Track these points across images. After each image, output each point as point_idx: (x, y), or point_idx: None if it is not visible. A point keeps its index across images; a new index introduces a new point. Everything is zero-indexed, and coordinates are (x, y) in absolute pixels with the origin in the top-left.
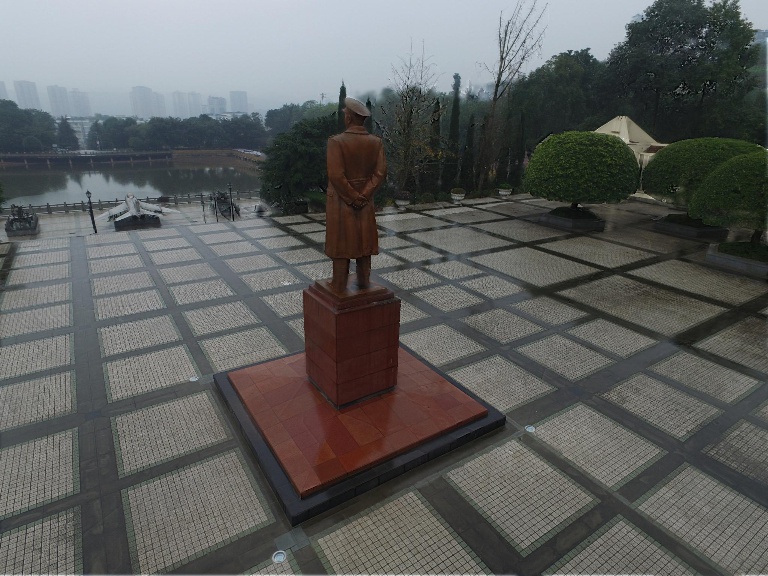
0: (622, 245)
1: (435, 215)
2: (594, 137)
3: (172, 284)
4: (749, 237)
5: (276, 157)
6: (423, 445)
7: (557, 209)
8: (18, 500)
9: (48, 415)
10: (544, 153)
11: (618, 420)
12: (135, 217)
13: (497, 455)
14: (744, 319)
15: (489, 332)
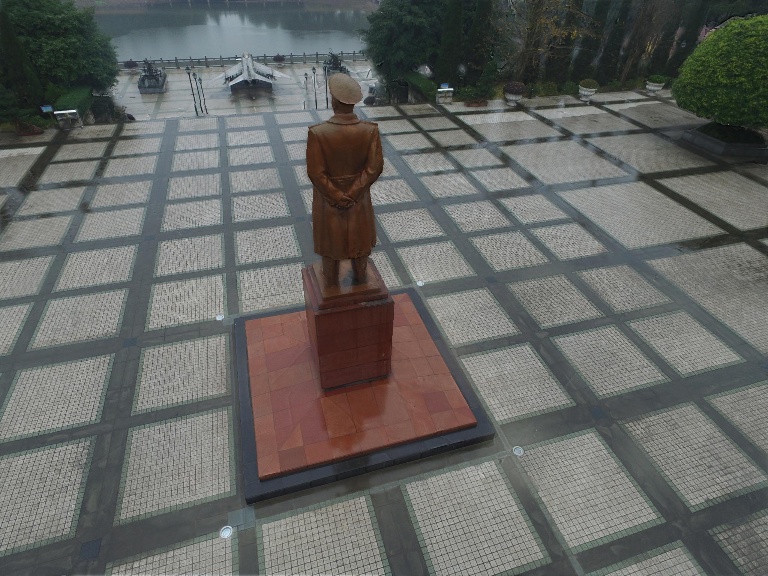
0: None
1: (548, 118)
2: None
3: (236, 194)
4: None
5: (380, 27)
6: (393, 449)
7: (711, 125)
8: (56, 418)
9: (97, 335)
10: (711, 48)
11: (627, 464)
12: (247, 82)
13: (467, 476)
14: None
15: (533, 309)
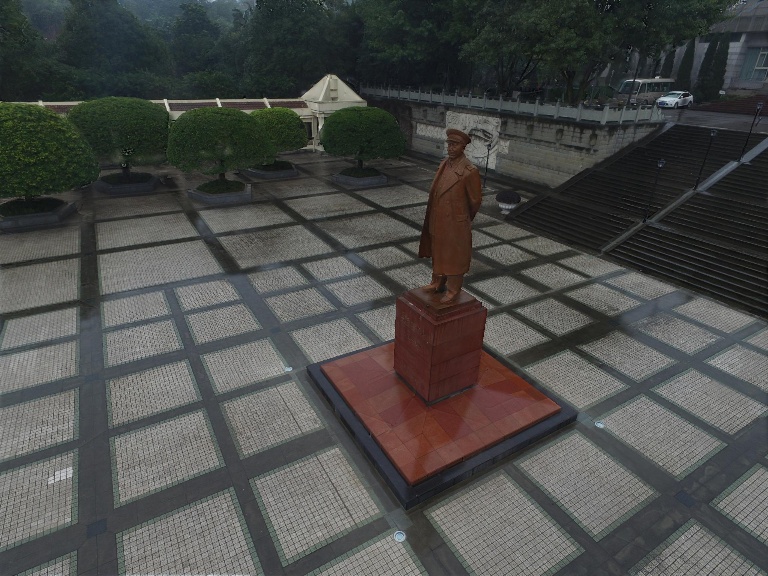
0: (144, 217)
1: None
2: (29, 110)
3: None
4: (172, 178)
5: None
6: None
7: (11, 207)
8: None
9: None
10: None
11: None
12: None
13: None
14: (317, 226)
15: (314, 312)
